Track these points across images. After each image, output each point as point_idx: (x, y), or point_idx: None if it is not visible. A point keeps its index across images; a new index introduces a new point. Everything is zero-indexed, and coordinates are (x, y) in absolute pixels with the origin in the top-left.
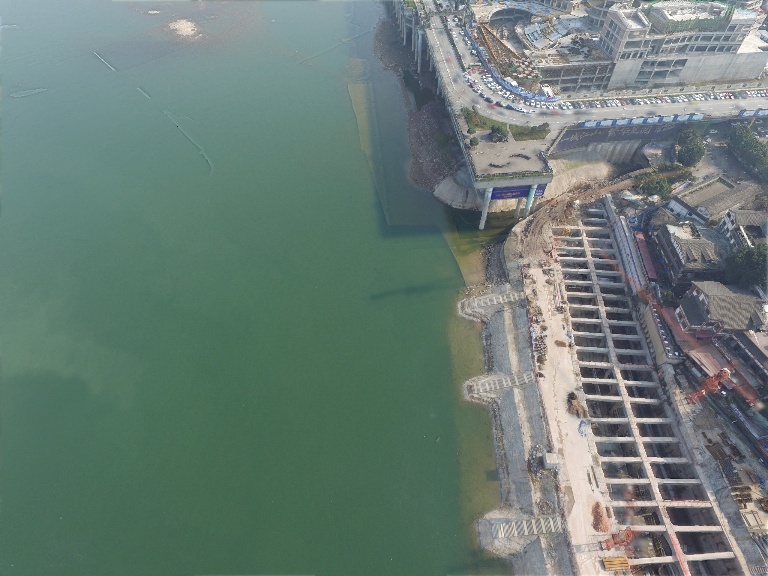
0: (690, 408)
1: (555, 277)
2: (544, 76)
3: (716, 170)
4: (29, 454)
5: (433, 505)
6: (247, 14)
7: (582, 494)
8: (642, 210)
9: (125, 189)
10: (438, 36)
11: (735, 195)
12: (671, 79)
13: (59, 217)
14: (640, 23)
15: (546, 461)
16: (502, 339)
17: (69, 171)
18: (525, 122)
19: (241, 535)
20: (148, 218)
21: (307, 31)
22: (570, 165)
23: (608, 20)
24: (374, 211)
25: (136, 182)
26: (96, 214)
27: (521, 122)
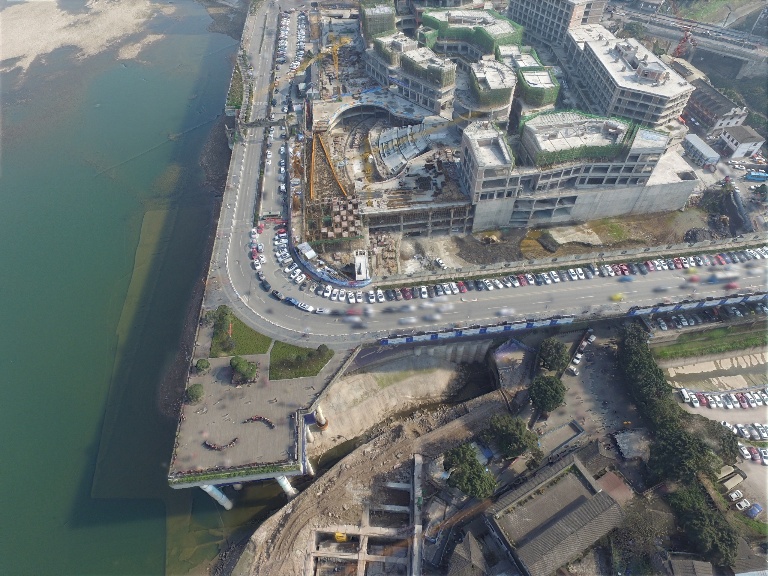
0: None
1: None
2: (377, 223)
3: (592, 403)
4: None
5: None
6: (69, 96)
7: None
8: (456, 507)
9: None
10: (248, 156)
11: (584, 528)
12: (560, 217)
13: None
14: (501, 155)
15: None
16: None
17: None
18: (301, 334)
19: None
20: None
21: (140, 118)
22: (387, 379)
23: (463, 145)
24: (82, 465)
25: None
26: None
27: (295, 335)
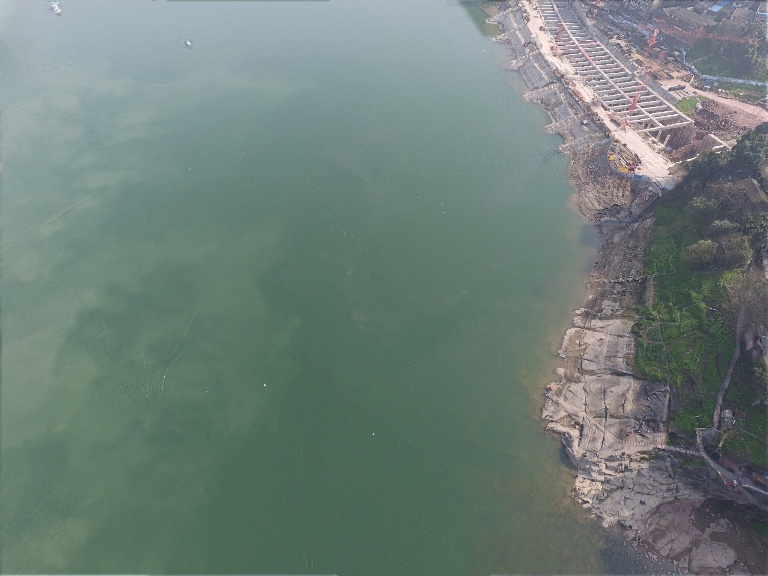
0: (592, 22)
1: (533, 2)
2: None
3: None
4: (304, 66)
5: (485, 63)
6: None
7: (546, 45)
8: None
9: (294, 4)
10: None
11: None
12: None
13: (265, 15)
14: None
15: (531, 37)
16: (509, 22)
17: (259, 0)
18: None
19: (407, 73)
20: (314, 11)
21: None
22: None
23: None
24: None
25: (299, 2)
26: (284, 13)
27: None
